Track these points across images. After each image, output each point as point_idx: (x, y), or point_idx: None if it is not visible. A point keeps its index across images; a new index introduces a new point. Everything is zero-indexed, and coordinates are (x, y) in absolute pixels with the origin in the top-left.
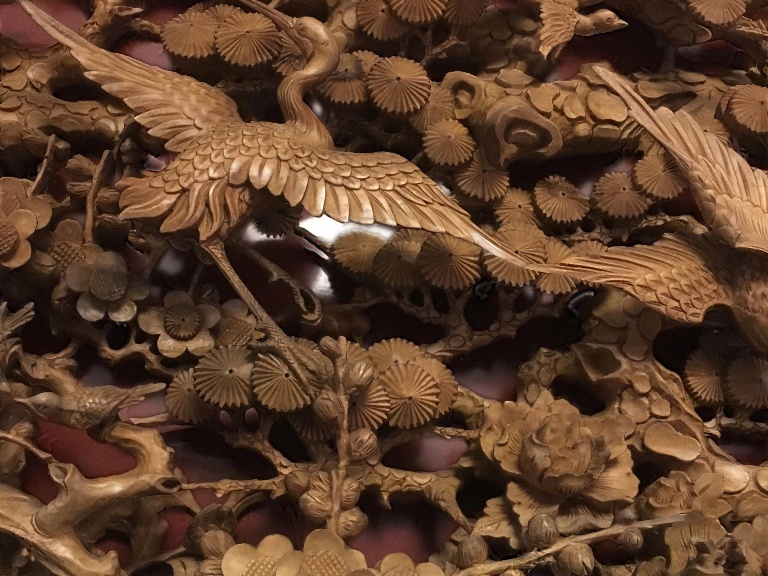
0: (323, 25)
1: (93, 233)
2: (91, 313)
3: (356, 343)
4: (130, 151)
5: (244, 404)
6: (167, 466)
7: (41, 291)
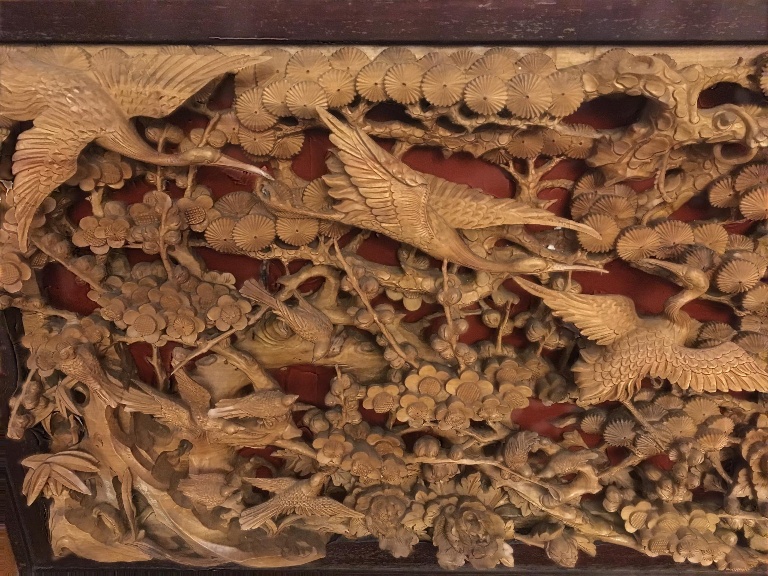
0: (703, 276)
1: None
2: (548, 402)
3: (687, 417)
4: (548, 284)
5: (628, 445)
6: (598, 483)
7: None
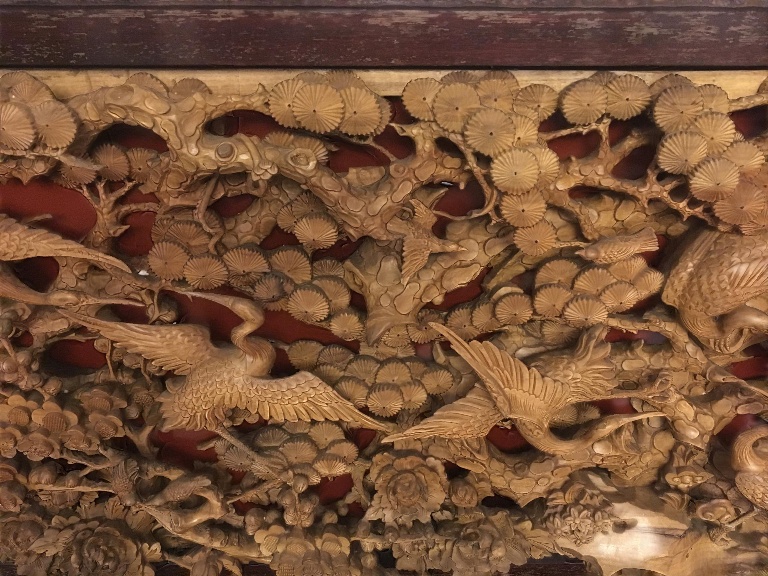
0: (249, 308)
1: (151, 379)
2: None
3: (302, 442)
4: None
5: None
6: (221, 508)
7: None
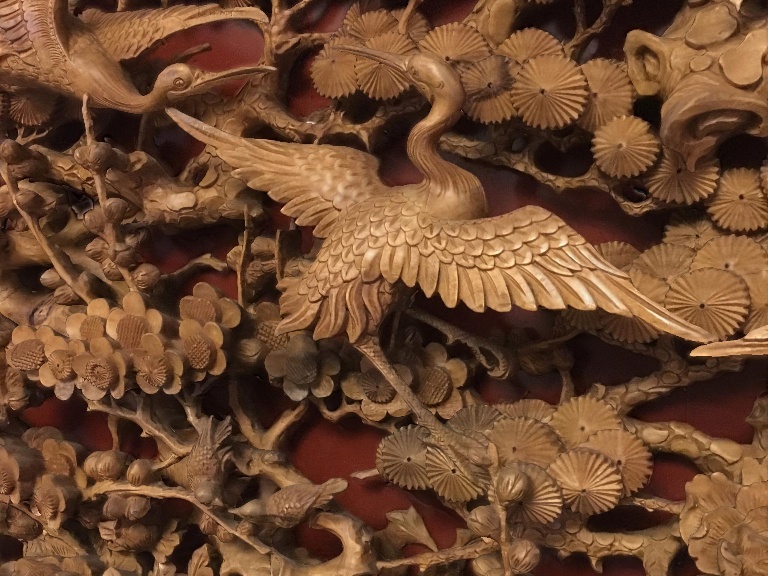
0: (435, 62)
1: None
2: (296, 393)
3: (530, 419)
4: None
5: (429, 487)
6: (361, 560)
7: (259, 370)
